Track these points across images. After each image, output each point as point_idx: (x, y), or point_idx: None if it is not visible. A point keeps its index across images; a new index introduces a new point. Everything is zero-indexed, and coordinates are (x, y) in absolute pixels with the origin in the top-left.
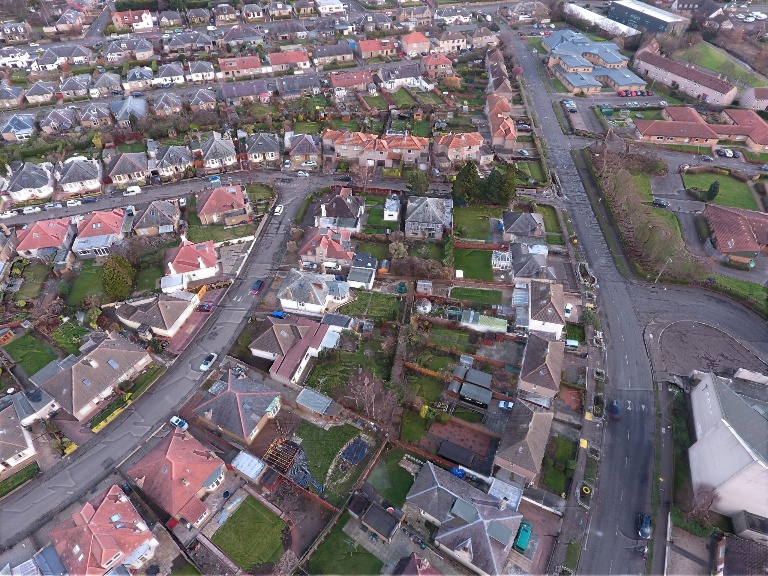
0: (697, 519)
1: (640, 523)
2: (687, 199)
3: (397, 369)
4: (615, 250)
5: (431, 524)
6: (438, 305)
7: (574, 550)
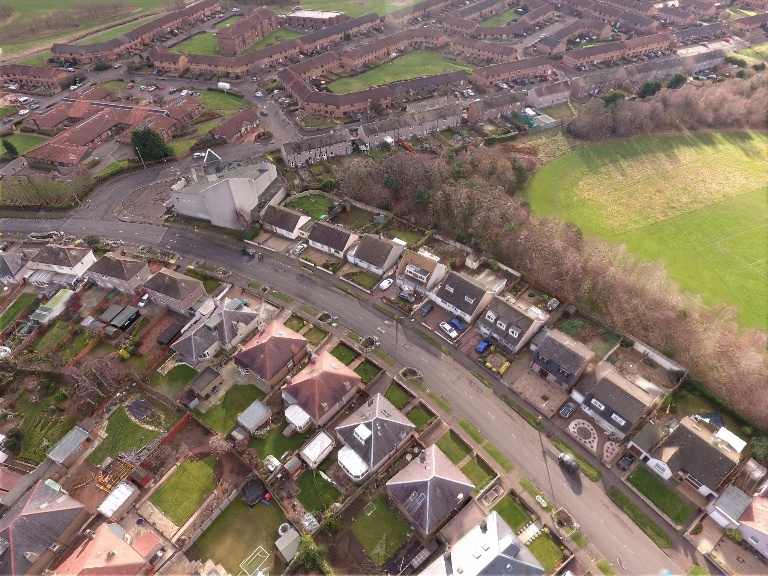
0: (250, 228)
1: (246, 252)
2: (5, 165)
3: (70, 370)
4: (30, 215)
5: (217, 354)
6: (7, 341)
7: (253, 284)
